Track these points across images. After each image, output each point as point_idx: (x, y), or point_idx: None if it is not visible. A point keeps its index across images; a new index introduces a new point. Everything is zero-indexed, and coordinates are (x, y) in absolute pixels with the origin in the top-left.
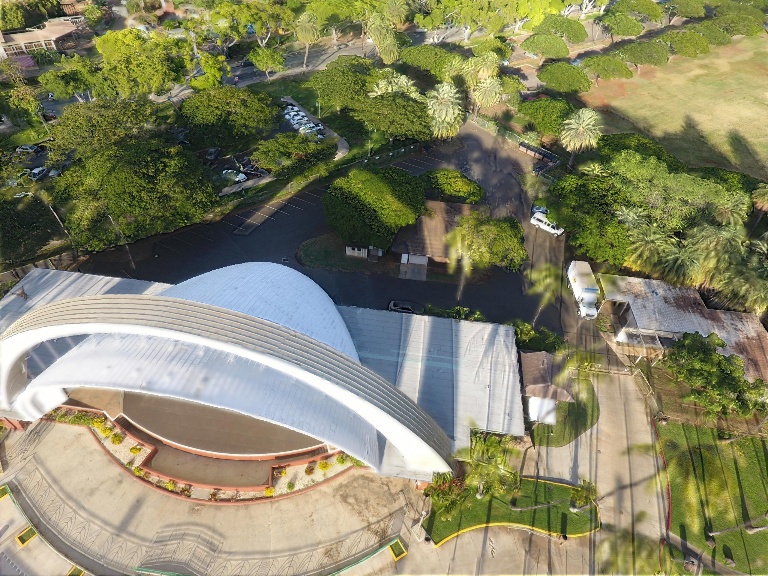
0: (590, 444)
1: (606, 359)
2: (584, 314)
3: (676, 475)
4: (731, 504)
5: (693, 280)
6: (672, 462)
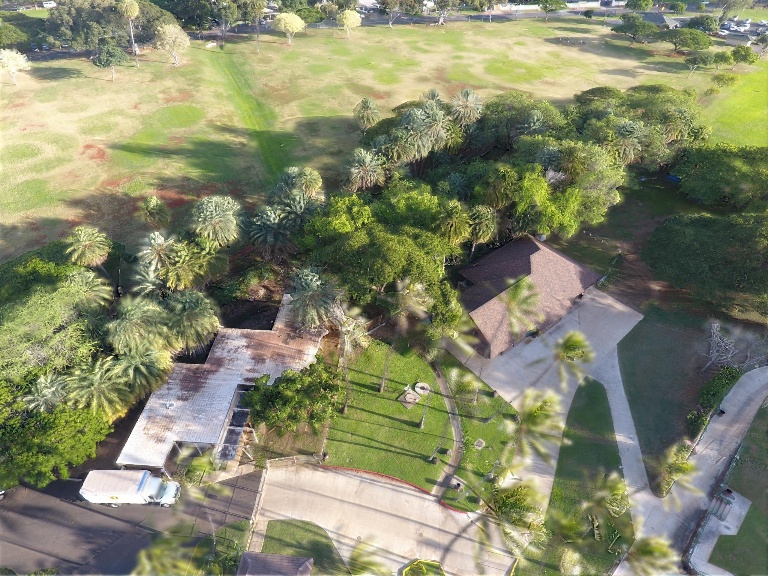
0: (351, 547)
1: (242, 491)
2: (172, 500)
3: (379, 466)
4: (401, 430)
5: (165, 362)
6: (367, 465)
